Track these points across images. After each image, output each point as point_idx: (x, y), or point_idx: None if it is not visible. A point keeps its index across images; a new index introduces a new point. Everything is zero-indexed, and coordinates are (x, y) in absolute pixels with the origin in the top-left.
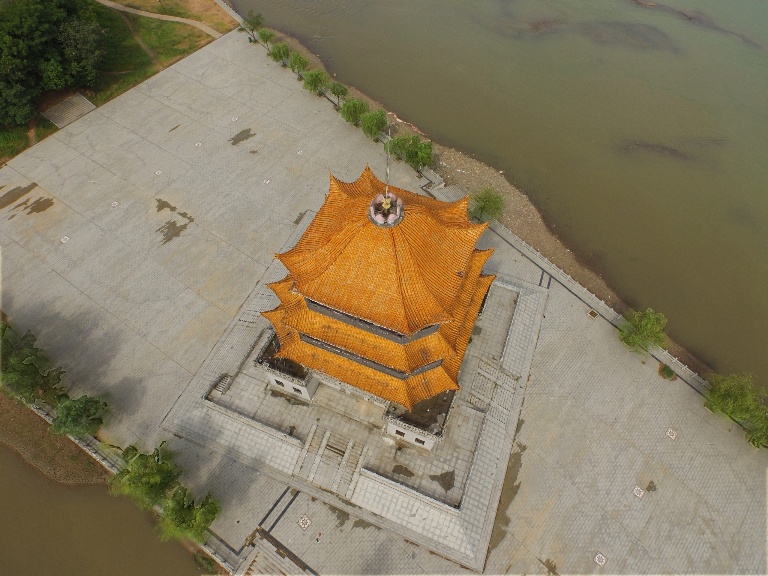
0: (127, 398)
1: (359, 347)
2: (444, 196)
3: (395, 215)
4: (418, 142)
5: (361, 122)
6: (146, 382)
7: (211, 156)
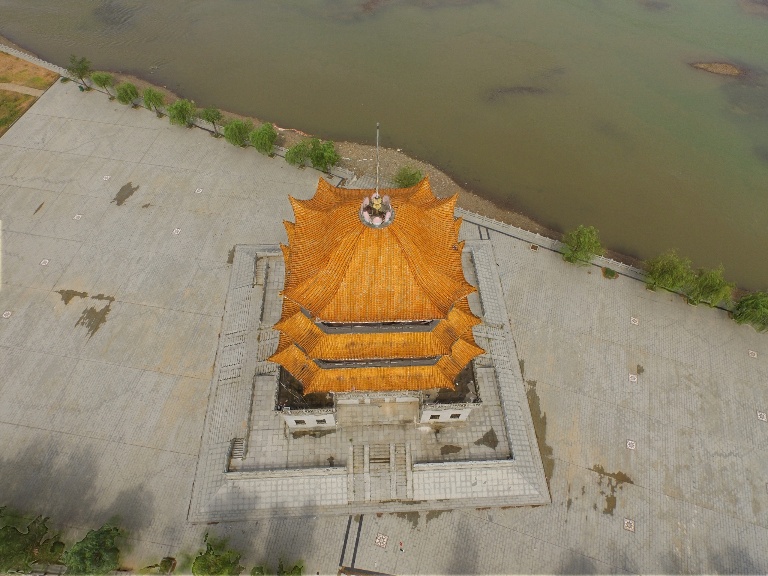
0: (134, 512)
1: (389, 350)
2: None
3: (390, 212)
4: (319, 144)
5: (247, 141)
6: (148, 486)
7: (99, 225)
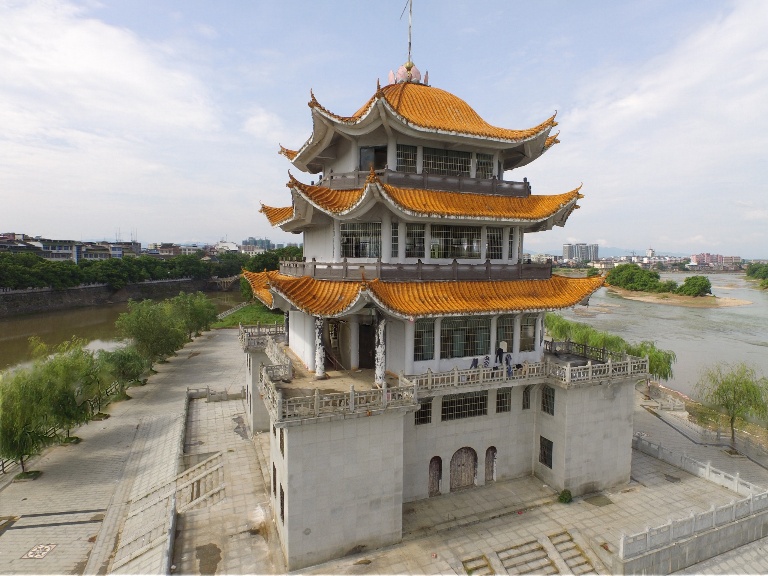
0: (163, 398)
1: None
2: (677, 419)
3: None
4: None
5: None
6: None
7: None
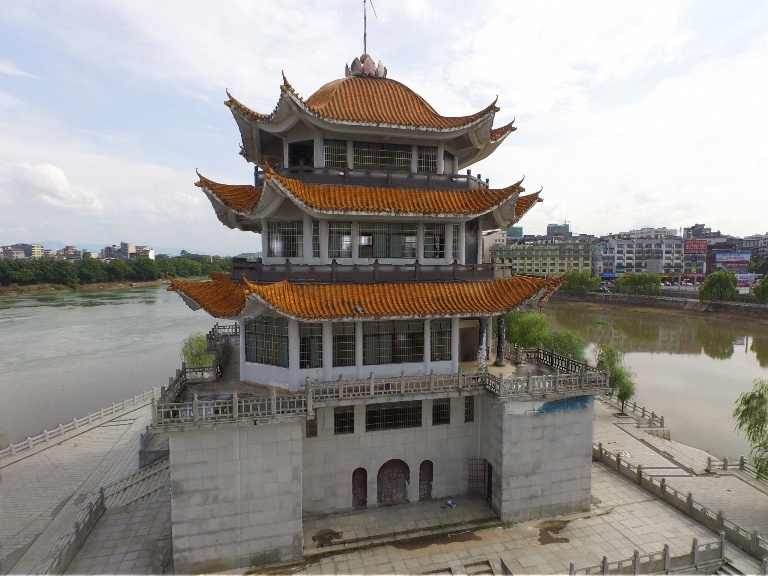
0: None
1: None
2: None
3: None
4: None
5: None
6: None
7: None
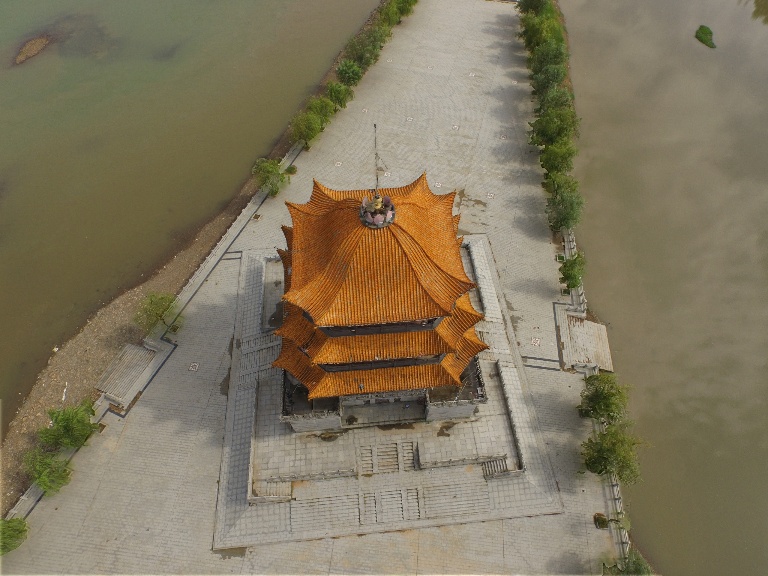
0: None
1: None
2: (133, 384)
3: (384, 197)
4: (51, 430)
5: None
6: (542, 571)
7: None
